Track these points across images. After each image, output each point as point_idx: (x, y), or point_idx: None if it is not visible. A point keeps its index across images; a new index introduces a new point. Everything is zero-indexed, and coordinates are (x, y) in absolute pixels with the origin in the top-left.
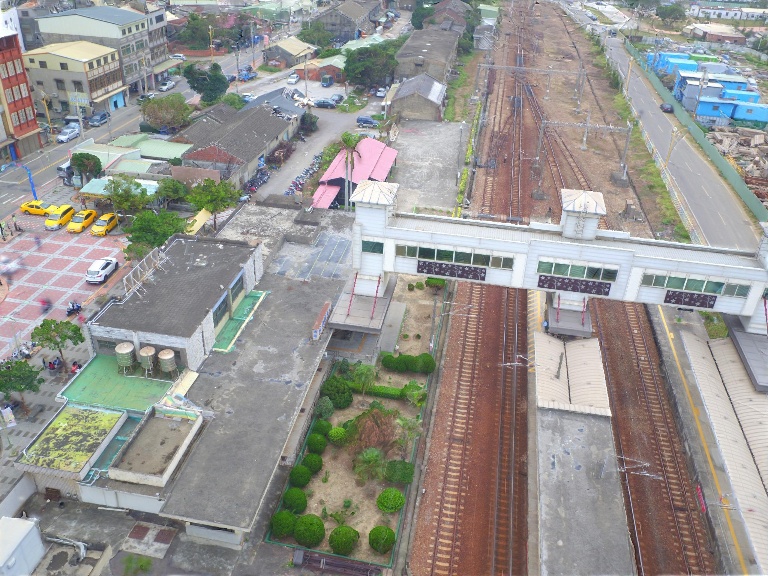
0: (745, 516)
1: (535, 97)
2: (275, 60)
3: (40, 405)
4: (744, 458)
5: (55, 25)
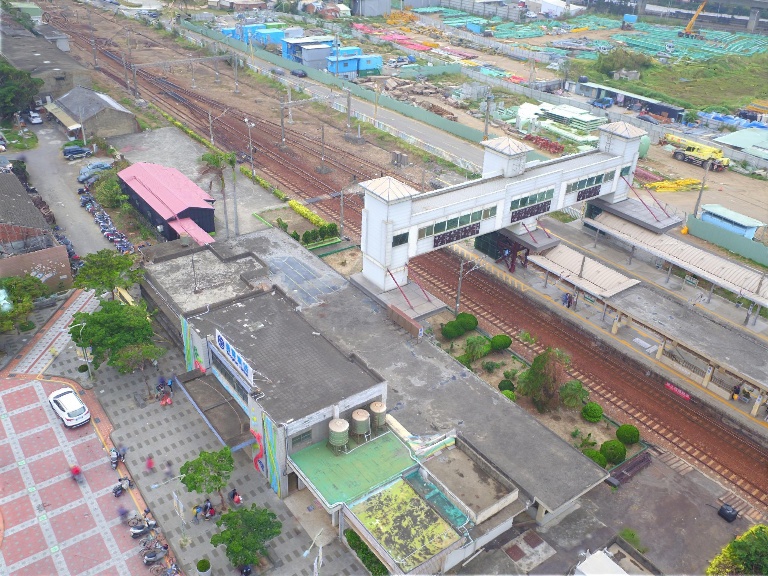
0: (749, 296)
1: (183, 88)
2: None
3: (268, 546)
4: None
5: None
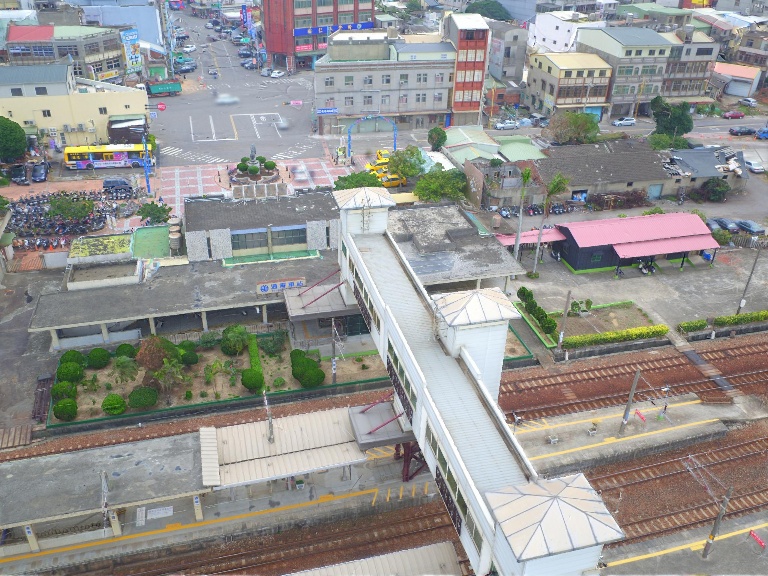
0: None
1: None
2: None
3: None
4: None
5: (587, 37)
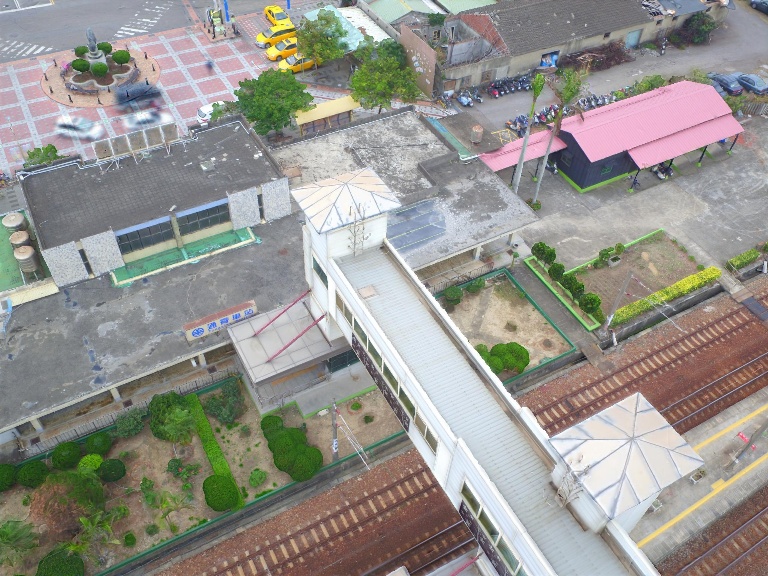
0: None
1: None
2: None
3: None
4: None
5: None
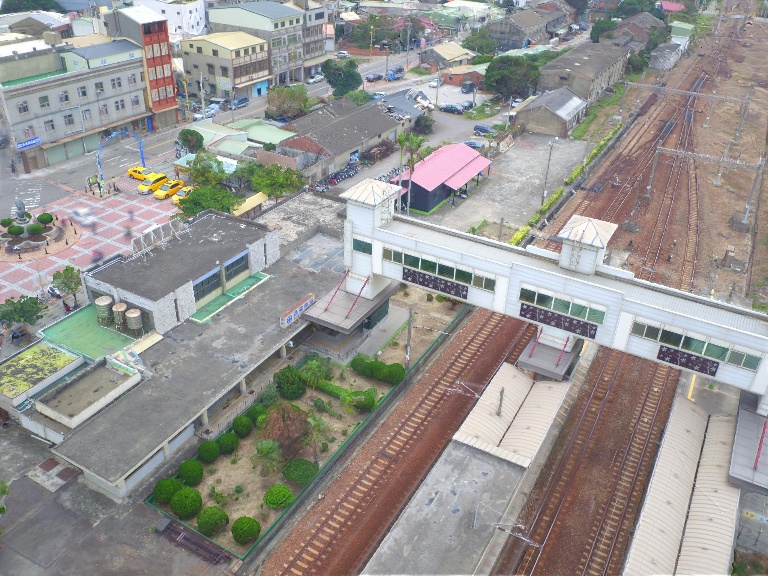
0: None
1: (692, 124)
2: (427, 63)
3: None
4: (662, 553)
5: (221, 16)
